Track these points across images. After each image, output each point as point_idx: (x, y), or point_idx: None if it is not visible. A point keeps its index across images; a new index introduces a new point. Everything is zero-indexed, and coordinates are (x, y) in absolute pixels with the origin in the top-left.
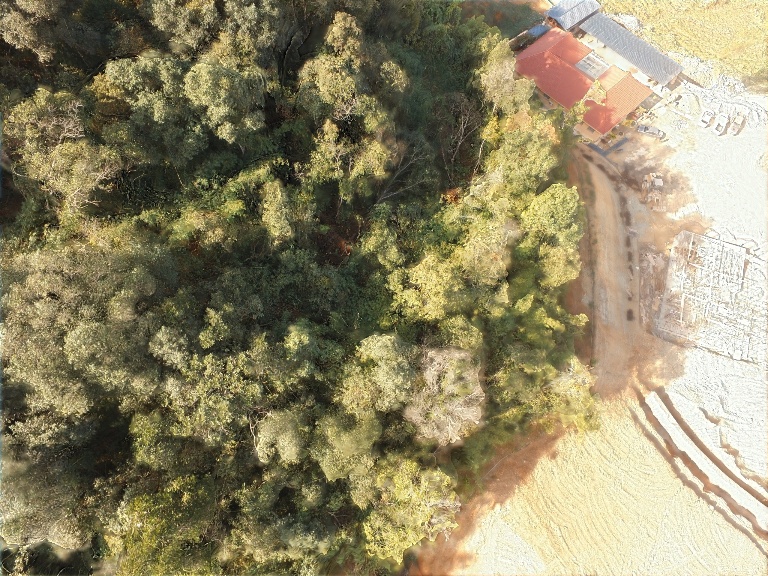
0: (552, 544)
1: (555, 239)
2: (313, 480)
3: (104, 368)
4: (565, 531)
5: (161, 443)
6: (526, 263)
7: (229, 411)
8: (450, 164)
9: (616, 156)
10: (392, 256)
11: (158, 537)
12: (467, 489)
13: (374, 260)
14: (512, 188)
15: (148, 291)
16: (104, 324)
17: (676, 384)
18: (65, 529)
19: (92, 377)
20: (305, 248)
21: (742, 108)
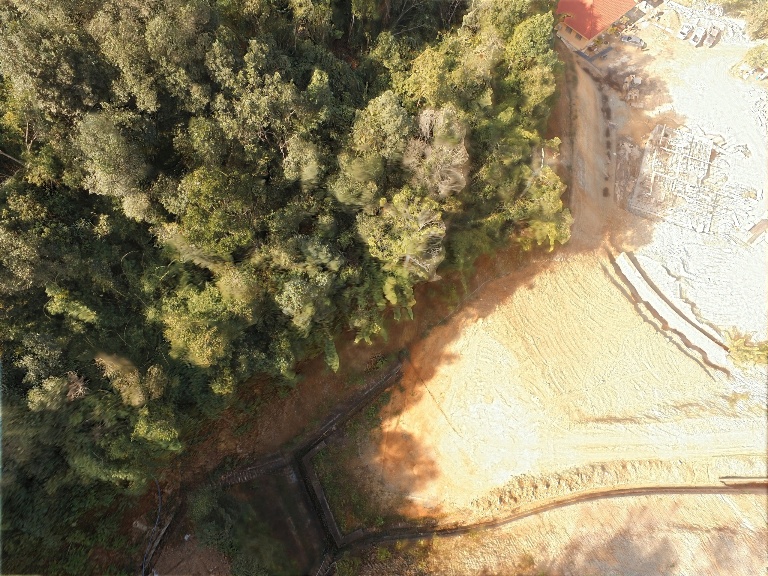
0: (526, 349)
1: (533, 62)
2: (327, 215)
3: (172, 66)
4: (538, 341)
5: (213, 138)
6: (510, 95)
7: (267, 106)
8: (447, 24)
9: (601, 62)
10: (395, 61)
11: (213, 191)
12: (454, 296)
13: (380, 69)
14: (499, 31)
15: (204, 20)
16: (175, 23)
17: (644, 250)
18: (138, 198)
19: (161, 77)
20: (323, 47)
21: (718, 24)
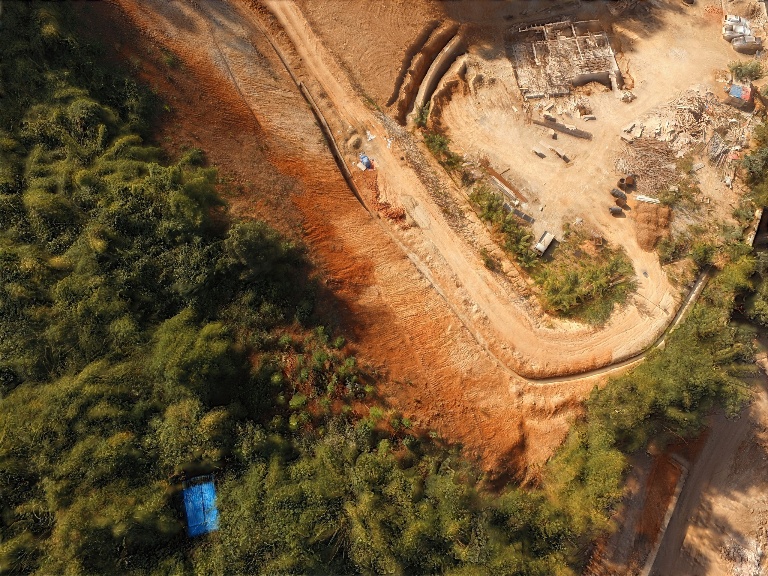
0: None
1: None
2: None
3: None
4: None
5: None
6: None
7: None
8: None
9: None
10: None
11: None
12: None
13: None
14: None
15: None
16: None
17: (476, 58)
18: None
19: None
20: None
21: None
